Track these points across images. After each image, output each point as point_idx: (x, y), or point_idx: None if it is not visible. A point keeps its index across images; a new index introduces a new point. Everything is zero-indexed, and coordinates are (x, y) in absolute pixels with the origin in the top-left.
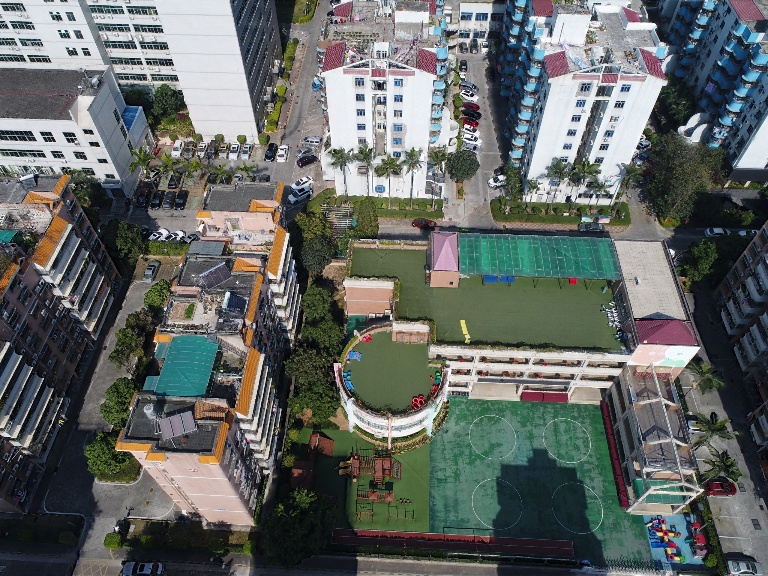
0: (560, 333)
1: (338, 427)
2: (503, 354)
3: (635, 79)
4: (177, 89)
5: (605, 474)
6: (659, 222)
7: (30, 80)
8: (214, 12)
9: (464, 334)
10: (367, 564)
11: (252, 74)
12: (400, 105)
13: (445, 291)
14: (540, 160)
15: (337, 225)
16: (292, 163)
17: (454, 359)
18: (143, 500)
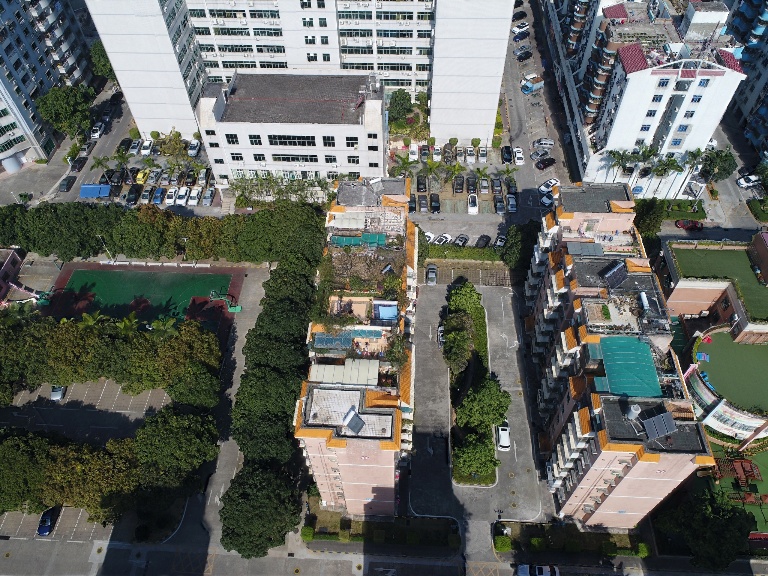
0: None
1: None
2: None
3: None
4: None
5: None
6: None
7: (295, 86)
8: (494, 15)
9: None
10: (761, 567)
11: None
12: (695, 105)
13: None
14: None
15: None
16: (530, 166)
17: None
18: (509, 503)
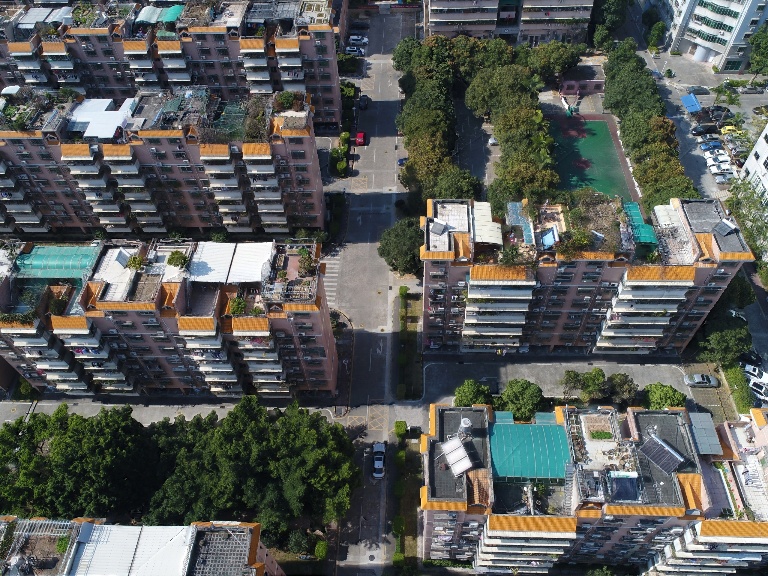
0: None
1: None
2: None
3: None
4: None
5: None
6: None
7: None
8: None
9: None
10: None
11: None
12: None
13: None
14: None
15: None
16: None
17: None
18: None
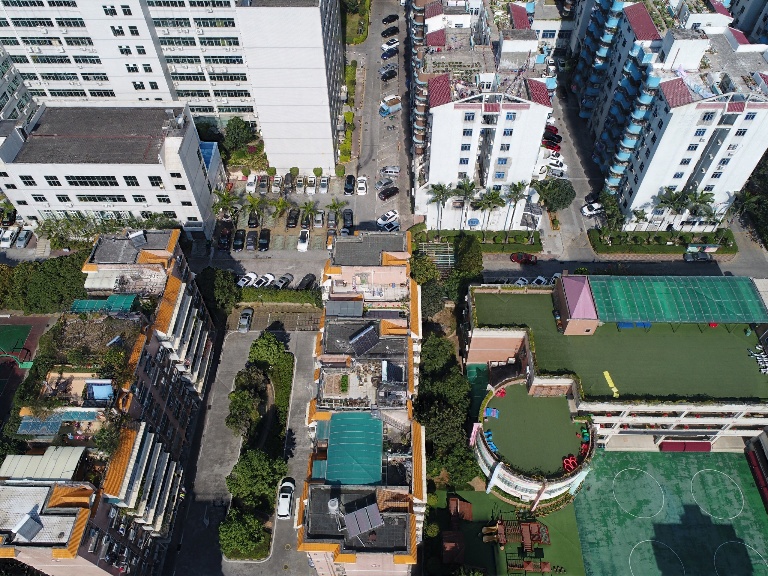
0: (712, 383)
1: (473, 488)
2: (656, 408)
3: (762, 107)
4: (244, 120)
5: (765, 530)
6: (766, 249)
7: (105, 120)
8: (304, 44)
9: (610, 387)
10: None
11: (332, 105)
12: (509, 139)
13: (580, 339)
14: (647, 189)
15: (439, 265)
16: (373, 196)
17: (597, 413)
18: None
